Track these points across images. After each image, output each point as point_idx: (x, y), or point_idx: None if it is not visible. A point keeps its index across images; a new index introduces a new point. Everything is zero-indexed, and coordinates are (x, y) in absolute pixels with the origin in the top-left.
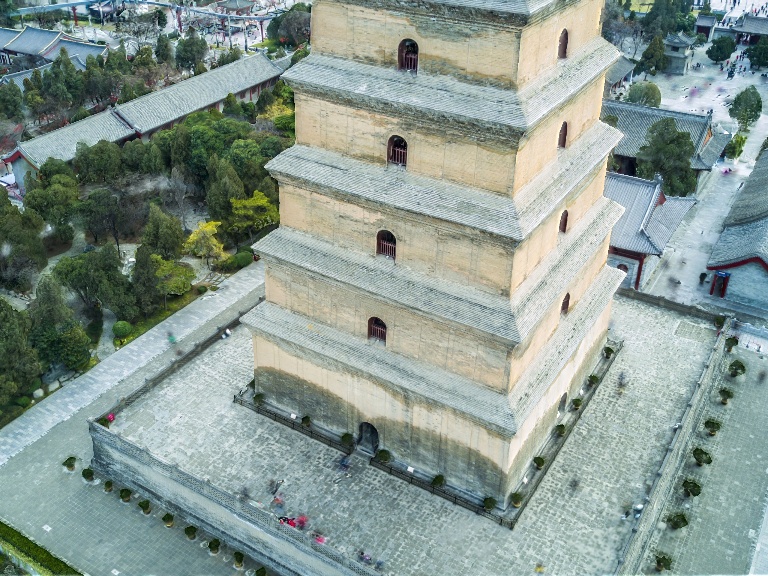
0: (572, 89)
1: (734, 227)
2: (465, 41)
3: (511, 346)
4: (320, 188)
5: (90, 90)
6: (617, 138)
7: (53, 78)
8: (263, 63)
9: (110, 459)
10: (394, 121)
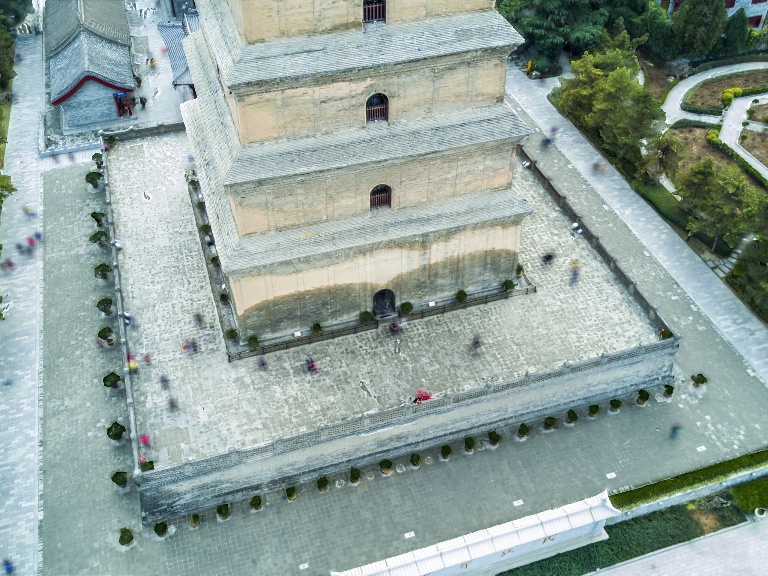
0: None
1: None
2: None
3: None
4: (298, 81)
5: None
6: None
7: None
8: None
9: (174, 497)
10: None
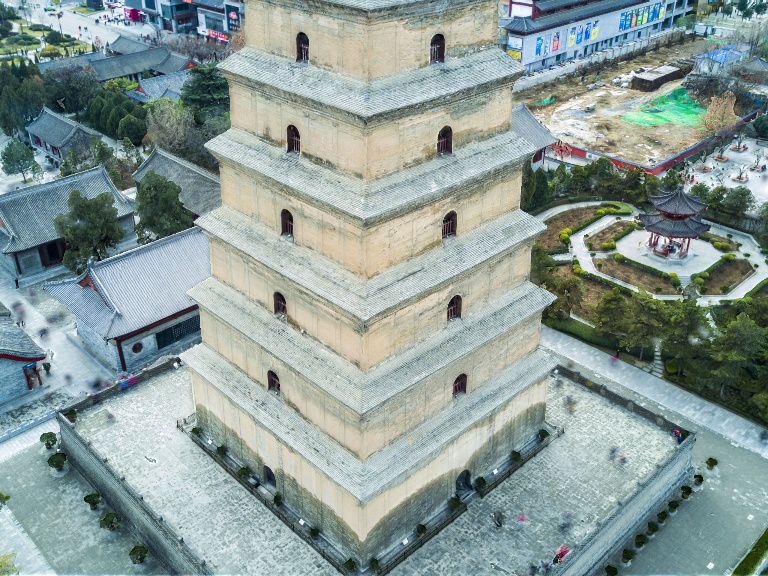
0: None
1: None
2: (483, 108)
3: None
4: None
5: None
6: None
7: None
8: None
9: None
10: (449, 200)
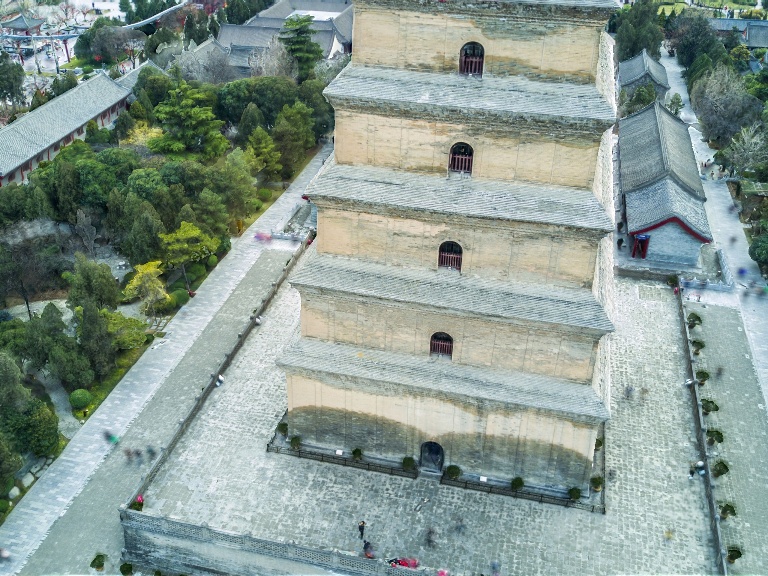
0: None
1: (634, 193)
2: (539, 39)
3: (600, 336)
4: (373, 207)
5: None
6: None
7: None
8: (107, 84)
9: (150, 546)
10: (459, 128)
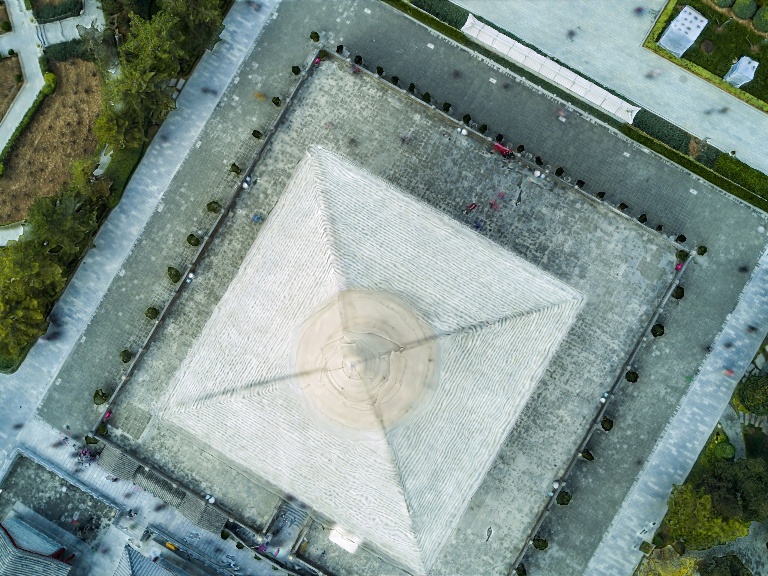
0: None
1: None
2: None
3: None
4: None
5: None
6: None
7: None
8: None
9: None
10: None
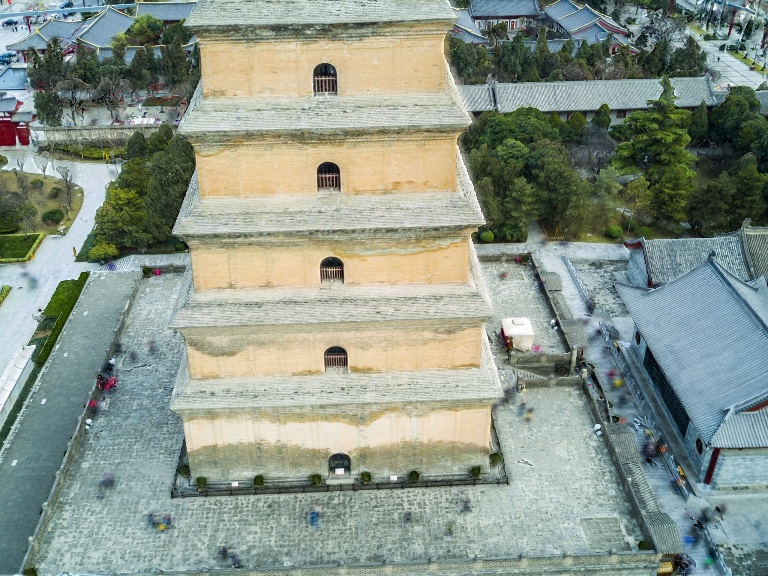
0: (305, 125)
1: None
2: None
3: None
4: None
5: (546, 70)
6: (464, 220)
7: (510, 50)
8: (699, 89)
9: None
10: None
